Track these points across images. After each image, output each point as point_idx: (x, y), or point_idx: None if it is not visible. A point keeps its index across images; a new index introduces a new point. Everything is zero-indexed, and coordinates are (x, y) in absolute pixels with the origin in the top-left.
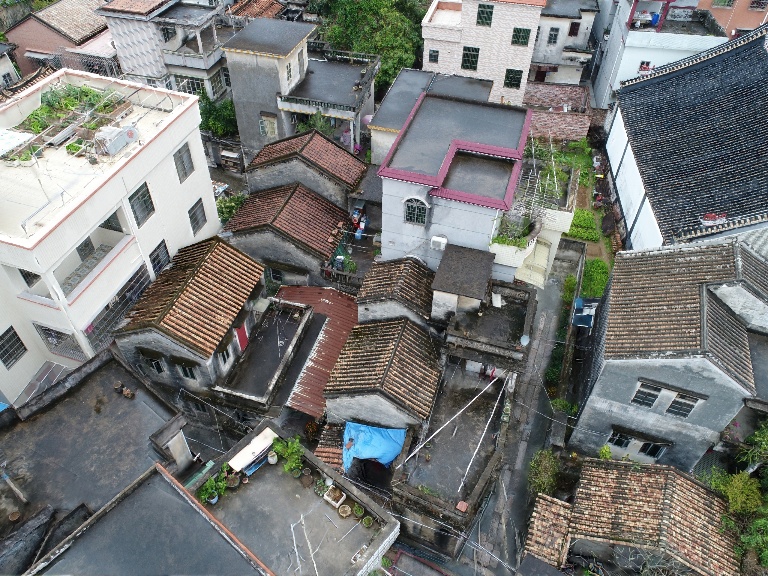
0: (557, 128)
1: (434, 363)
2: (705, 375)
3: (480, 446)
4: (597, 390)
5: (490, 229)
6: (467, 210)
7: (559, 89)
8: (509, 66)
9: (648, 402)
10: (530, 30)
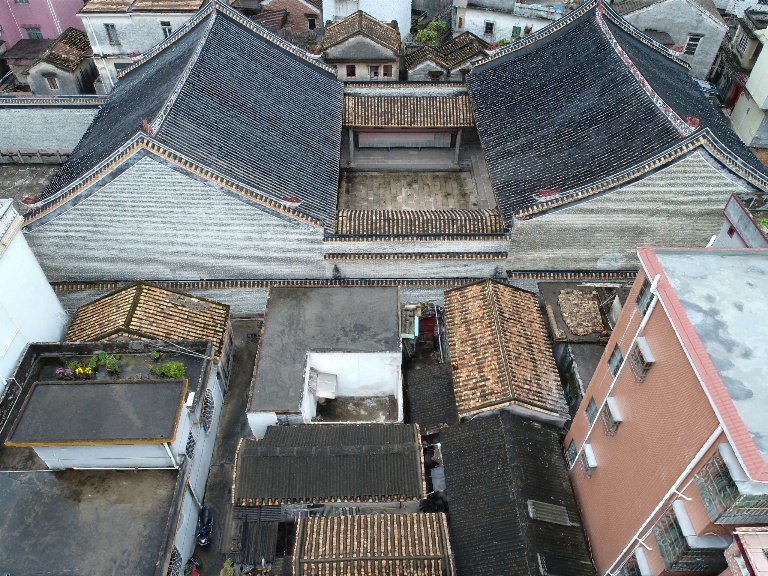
0: None
1: None
2: None
3: None
4: None
5: None
6: None
7: None
8: None
9: None
10: None
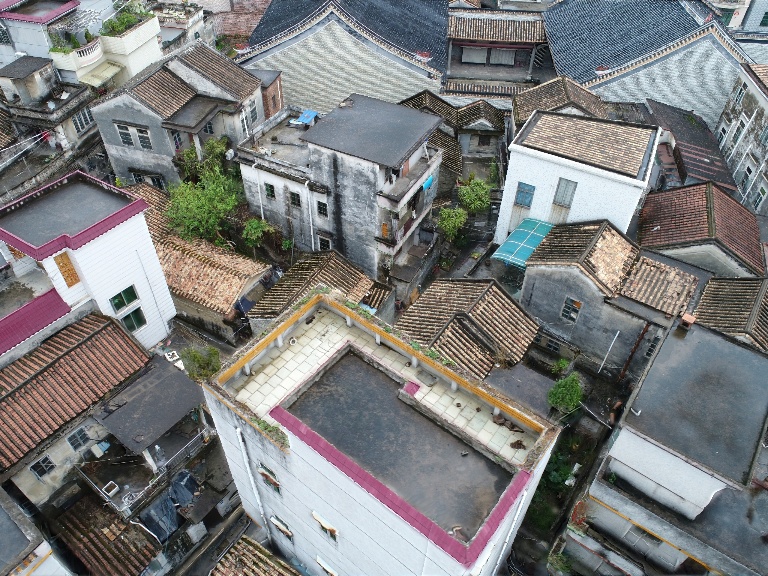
0: (245, 26)
1: (12, 133)
2: (136, 108)
3: None
4: (103, 138)
5: (46, 42)
6: (26, 28)
7: (259, 0)
8: None
9: (130, 141)
10: None
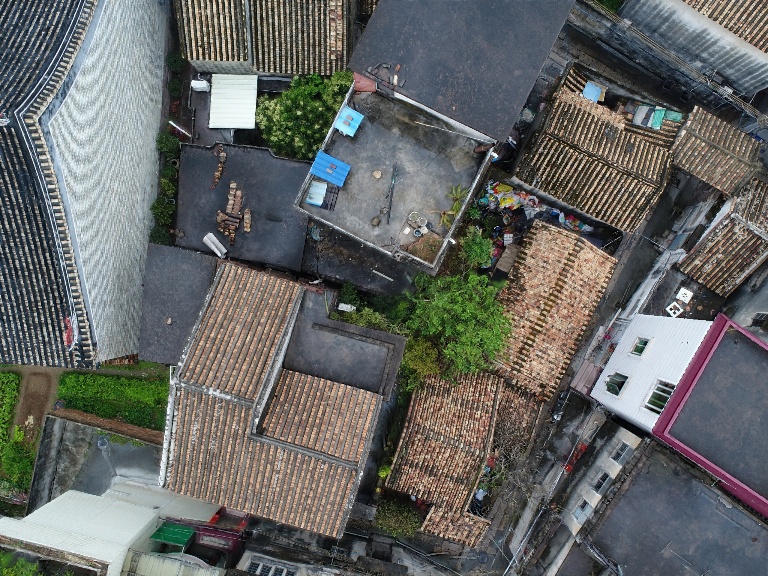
0: None
1: None
2: None
3: None
4: None
5: None
6: None
7: None
8: None
9: None
10: None
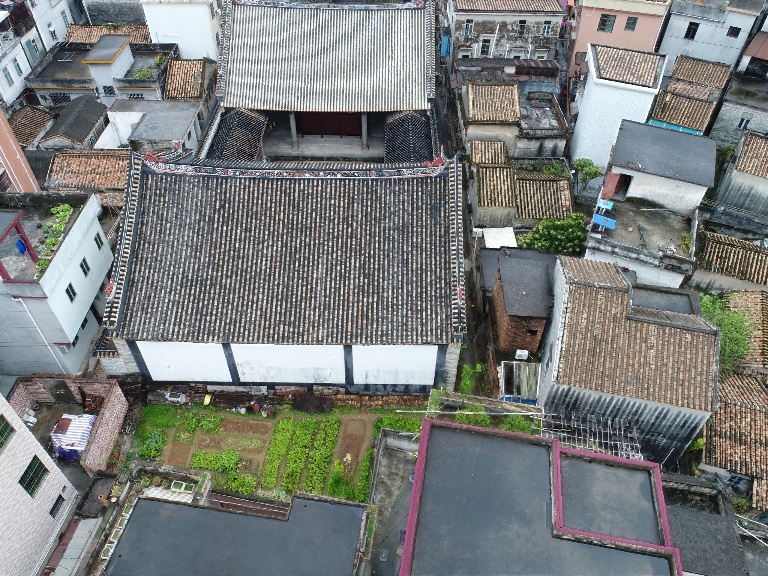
0: (108, 435)
1: None
2: None
3: (765, 555)
4: None
5: None
6: None
7: None
8: (18, 476)
9: None
10: (1, 416)
